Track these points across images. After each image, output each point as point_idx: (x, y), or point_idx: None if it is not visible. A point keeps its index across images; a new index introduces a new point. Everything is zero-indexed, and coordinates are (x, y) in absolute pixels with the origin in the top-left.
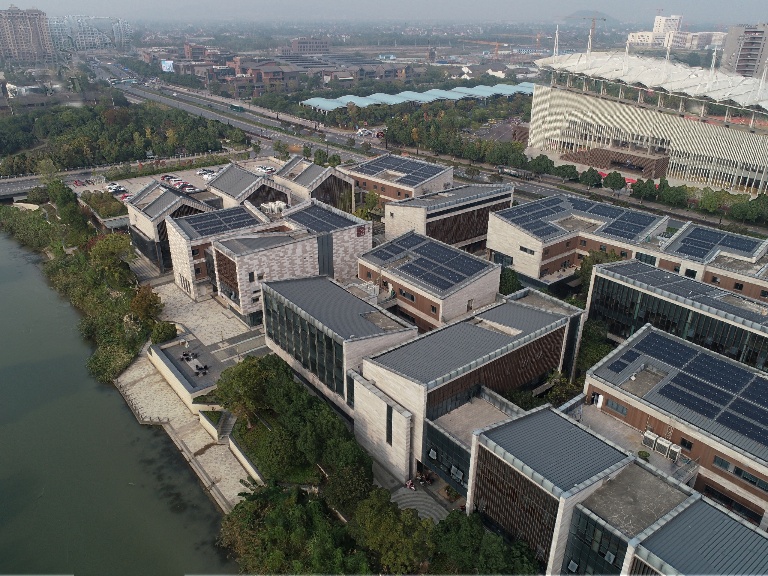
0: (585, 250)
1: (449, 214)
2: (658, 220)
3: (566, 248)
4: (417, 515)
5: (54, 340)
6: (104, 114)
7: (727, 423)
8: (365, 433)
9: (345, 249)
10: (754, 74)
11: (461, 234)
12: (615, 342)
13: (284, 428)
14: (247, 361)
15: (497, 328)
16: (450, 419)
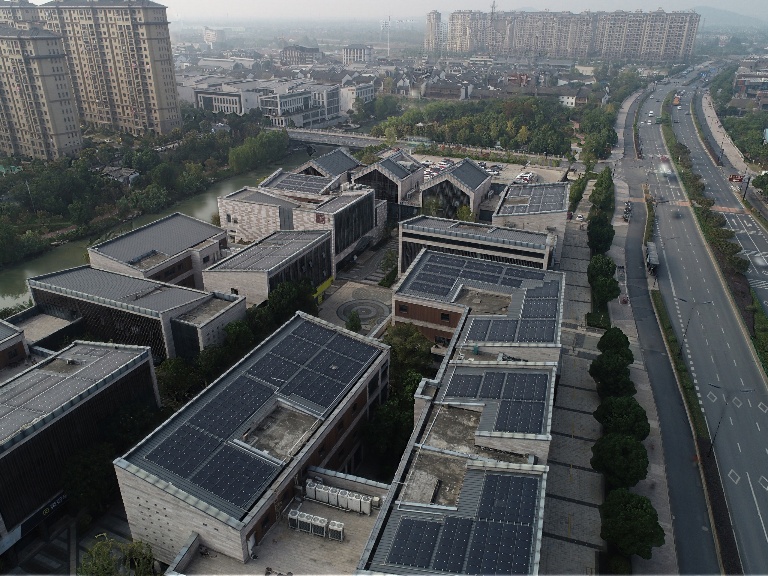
0: None
1: (435, 243)
2: None
3: (443, 320)
4: None
5: None
6: (503, 105)
7: None
8: None
9: None
10: None
11: None
12: None
13: None
14: None
15: None
16: (48, 319)
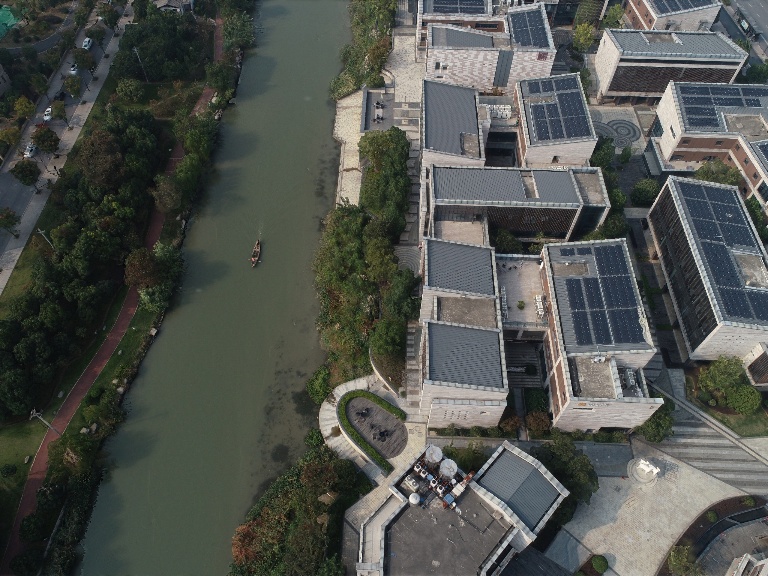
0: (735, 155)
1: (648, 64)
2: None
3: (716, 145)
4: (397, 261)
5: (328, 52)
6: None
7: (576, 317)
8: (419, 207)
9: (523, 67)
10: None
11: (657, 85)
12: (653, 241)
13: (378, 181)
14: (384, 131)
15: (534, 187)
16: (450, 225)
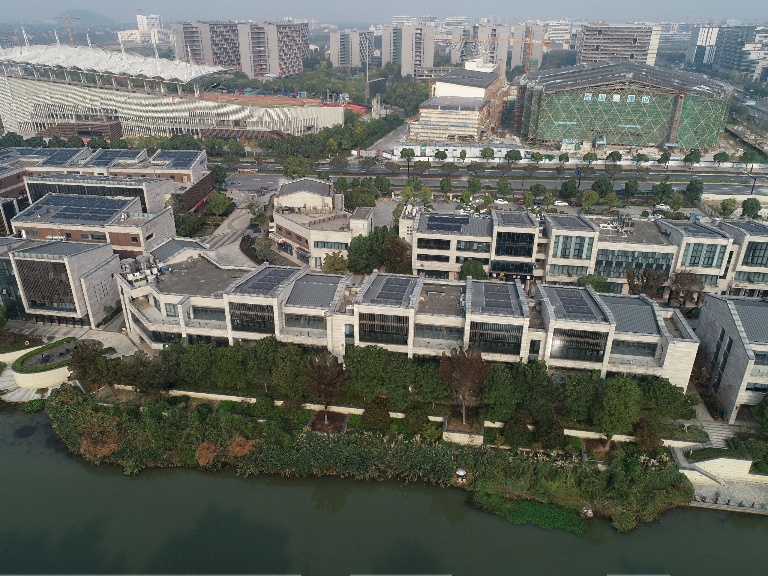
0: None
1: None
2: (81, 151)
3: (18, 180)
4: None
5: None
6: None
7: (84, 218)
8: None
9: None
10: (150, 55)
11: None
12: None
13: None
14: None
15: None
16: None
